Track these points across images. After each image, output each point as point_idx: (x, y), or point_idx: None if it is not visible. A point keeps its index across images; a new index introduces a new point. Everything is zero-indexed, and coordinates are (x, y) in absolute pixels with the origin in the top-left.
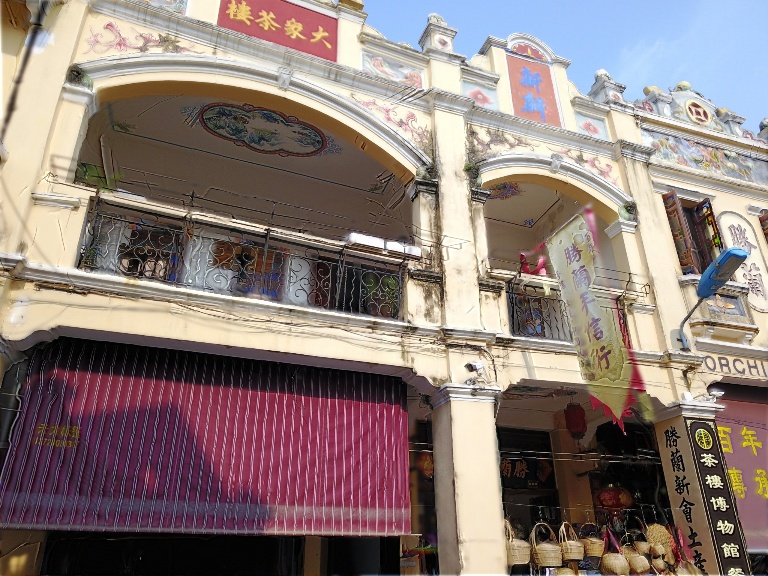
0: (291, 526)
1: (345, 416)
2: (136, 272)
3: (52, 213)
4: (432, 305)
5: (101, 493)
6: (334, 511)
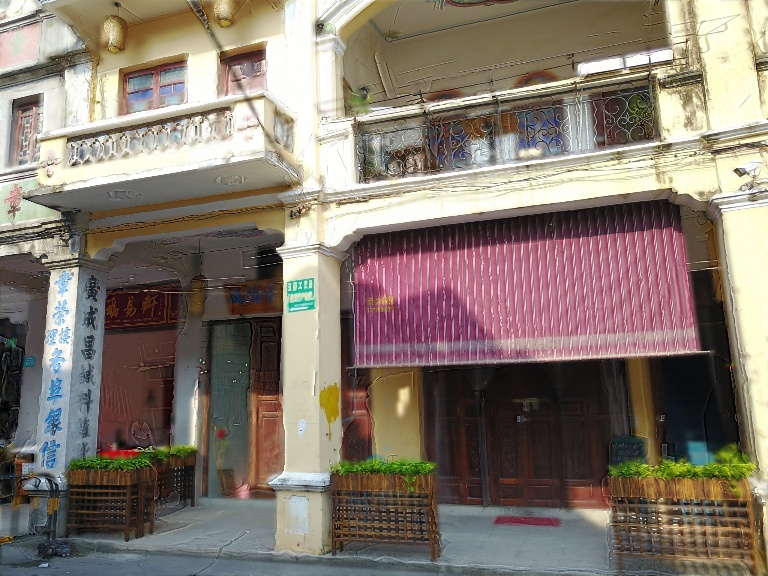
0: (568, 353)
1: (610, 250)
2: (400, 172)
3: (333, 147)
4: (693, 111)
5: (416, 341)
6: (608, 337)
